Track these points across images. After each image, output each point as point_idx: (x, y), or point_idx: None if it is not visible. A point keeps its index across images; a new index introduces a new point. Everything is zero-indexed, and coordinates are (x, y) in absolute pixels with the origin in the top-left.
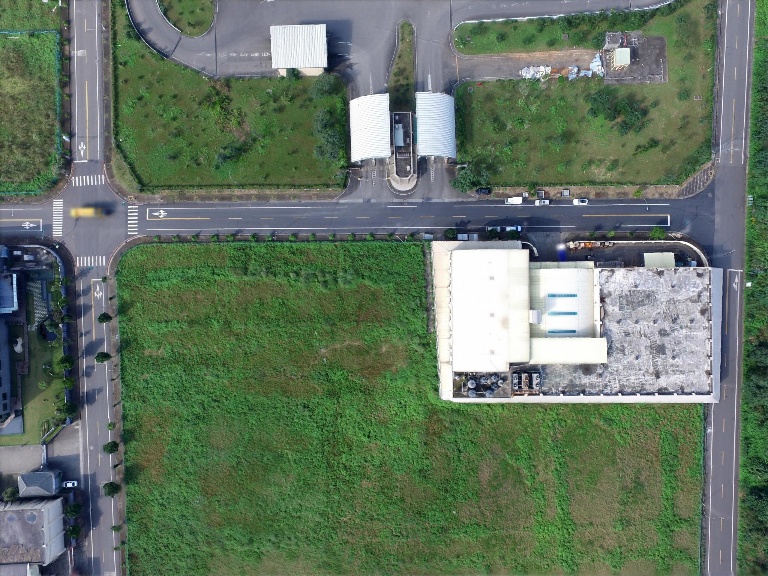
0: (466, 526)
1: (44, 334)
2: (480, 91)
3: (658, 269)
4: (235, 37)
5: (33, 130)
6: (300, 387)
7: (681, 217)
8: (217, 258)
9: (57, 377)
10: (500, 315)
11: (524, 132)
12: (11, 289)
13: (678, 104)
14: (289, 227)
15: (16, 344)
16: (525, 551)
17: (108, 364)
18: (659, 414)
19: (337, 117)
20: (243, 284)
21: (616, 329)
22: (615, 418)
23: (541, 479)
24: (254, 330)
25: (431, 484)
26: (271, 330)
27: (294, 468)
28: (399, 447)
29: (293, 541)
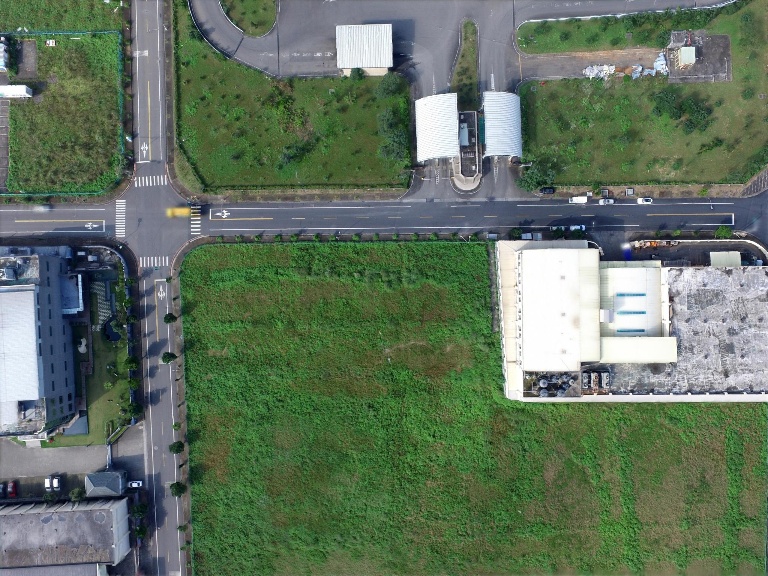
0: (532, 525)
1: (108, 334)
2: (543, 90)
3: (726, 268)
4: (297, 37)
5: (96, 131)
6: (365, 387)
7: (746, 216)
8: (280, 258)
9: (121, 377)
10: (571, 314)
11: (588, 131)
12: (76, 290)
13: (742, 103)
14: (352, 227)
15: (80, 345)
16: (591, 550)
17: (172, 364)
18: (724, 413)
19: (400, 117)
20: (307, 284)
21: (685, 328)
22: (680, 417)
23: (606, 478)
24: (318, 330)
25: (496, 483)
26: (335, 330)
27: (359, 468)
28: (464, 447)
29: (359, 541)
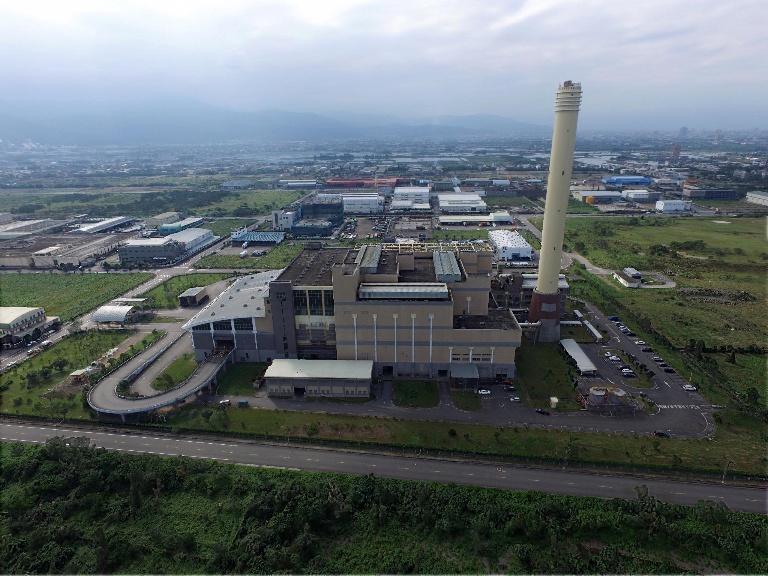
0: None
1: None
2: None
3: None
4: None
5: None
6: None
7: None
8: None
9: None
10: None
11: None
12: None
13: None
14: None
15: None
16: None
17: None
18: None
19: None
20: None
21: None
22: None
23: None
24: None
25: None
26: None
27: None
28: None
29: None
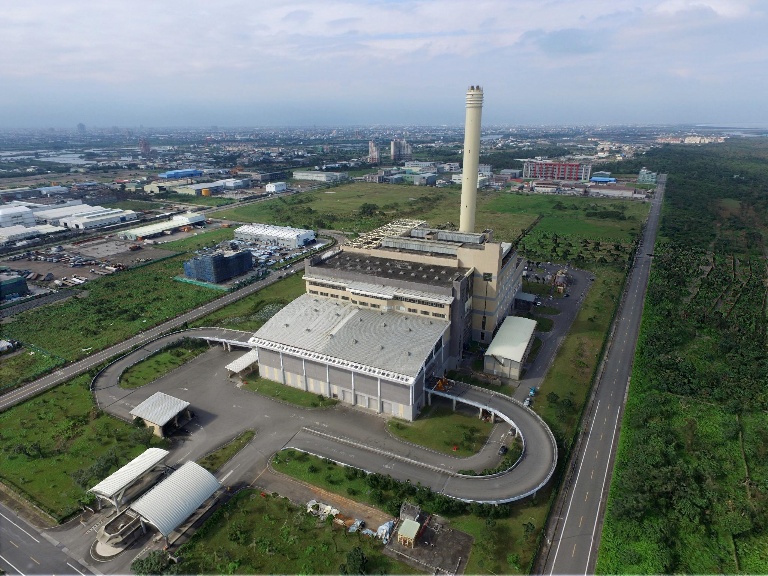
0: None
1: None
2: (259, 501)
3: None
4: (142, 397)
5: None
6: None
7: None
8: None
9: None
10: None
11: (263, 558)
12: None
13: None
14: None
15: None
16: None
17: None
18: None
19: None
20: None
21: None
22: None
23: None
24: None
25: None
26: None
27: None
28: None
29: None
